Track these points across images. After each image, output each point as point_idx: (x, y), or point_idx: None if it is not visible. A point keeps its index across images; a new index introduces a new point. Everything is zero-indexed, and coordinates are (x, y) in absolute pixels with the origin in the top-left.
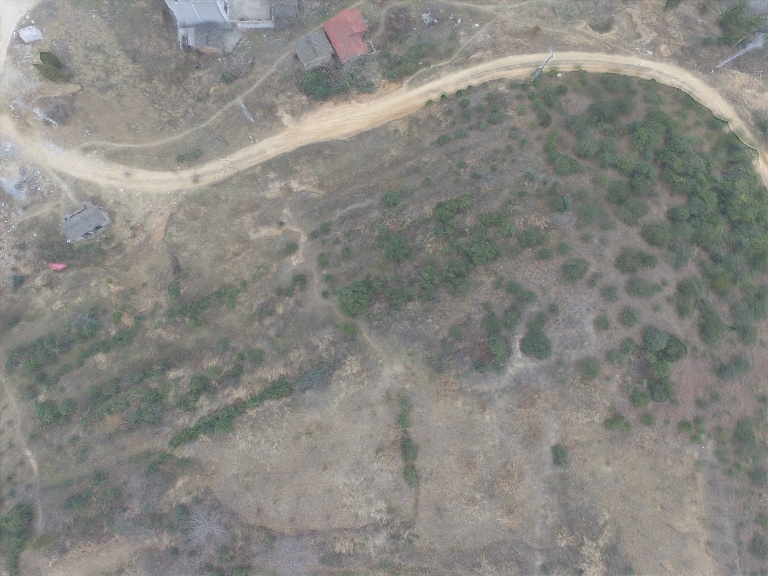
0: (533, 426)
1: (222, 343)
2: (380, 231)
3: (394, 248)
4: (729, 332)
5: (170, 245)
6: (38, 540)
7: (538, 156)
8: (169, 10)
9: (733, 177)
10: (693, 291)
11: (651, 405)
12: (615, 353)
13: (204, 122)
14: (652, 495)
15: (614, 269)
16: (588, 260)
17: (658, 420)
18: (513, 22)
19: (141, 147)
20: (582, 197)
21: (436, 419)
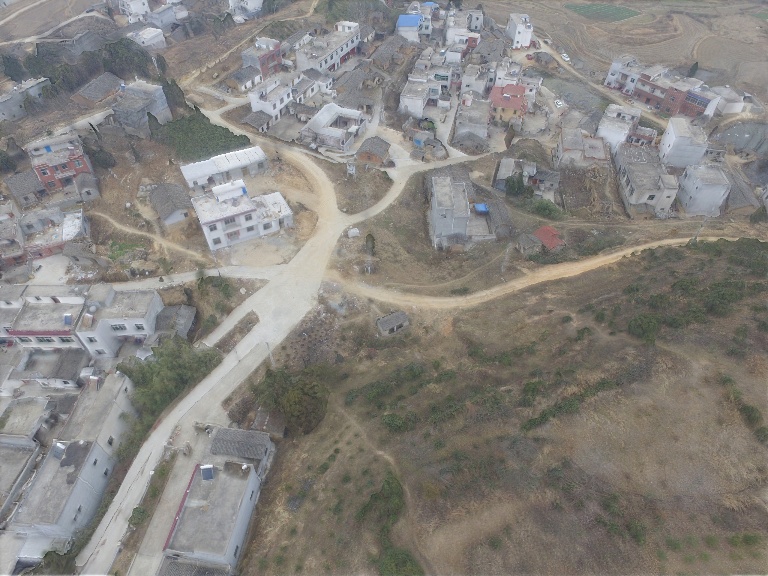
0: None
1: (537, 369)
2: (637, 299)
3: (660, 296)
4: None
5: (460, 332)
6: None
7: (726, 265)
8: (426, 233)
9: None
10: None
11: None
12: None
13: (463, 276)
14: None
15: None
16: None
17: None
18: (654, 231)
19: (423, 287)
20: None
21: (762, 391)
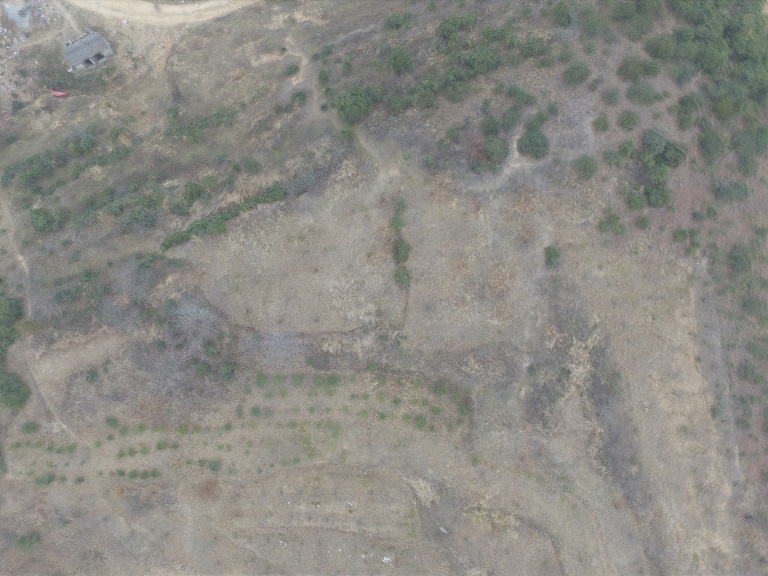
0: (527, 226)
1: (218, 155)
2: (382, 48)
3: (395, 55)
4: (730, 151)
5: (171, 74)
6: (26, 322)
7: None
8: None
9: (741, 16)
10: (695, 107)
11: (647, 210)
12: (613, 154)
13: None
14: (644, 305)
15: (616, 78)
16: (590, 69)
17: (653, 225)
18: None
19: None
20: (587, 15)
21: (429, 220)
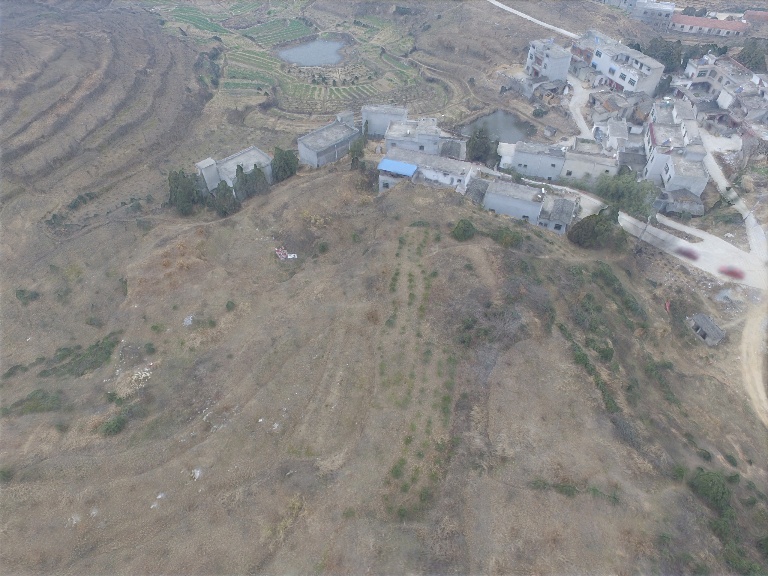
0: None
1: None
2: None
3: None
4: None
5: (702, 377)
6: None
7: None
8: None
9: None
10: None
11: None
12: None
13: None
14: None
15: None
16: None
17: None
18: None
19: None
20: None
21: (601, 525)
